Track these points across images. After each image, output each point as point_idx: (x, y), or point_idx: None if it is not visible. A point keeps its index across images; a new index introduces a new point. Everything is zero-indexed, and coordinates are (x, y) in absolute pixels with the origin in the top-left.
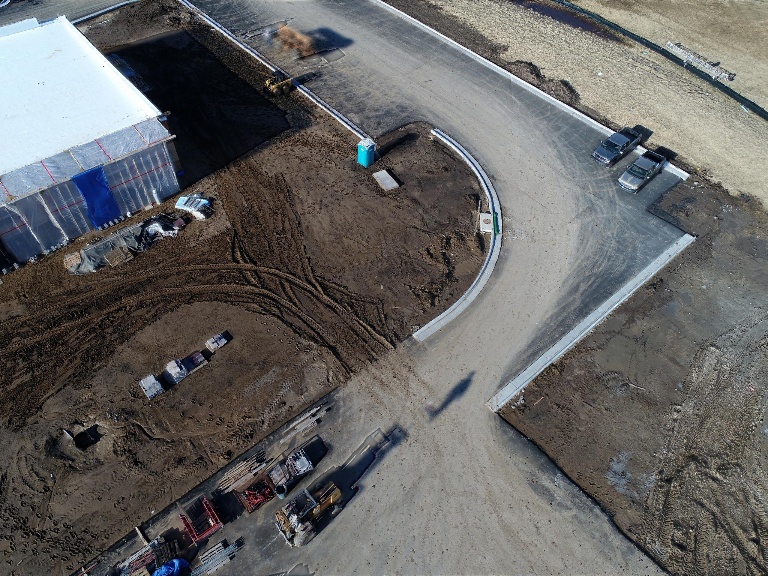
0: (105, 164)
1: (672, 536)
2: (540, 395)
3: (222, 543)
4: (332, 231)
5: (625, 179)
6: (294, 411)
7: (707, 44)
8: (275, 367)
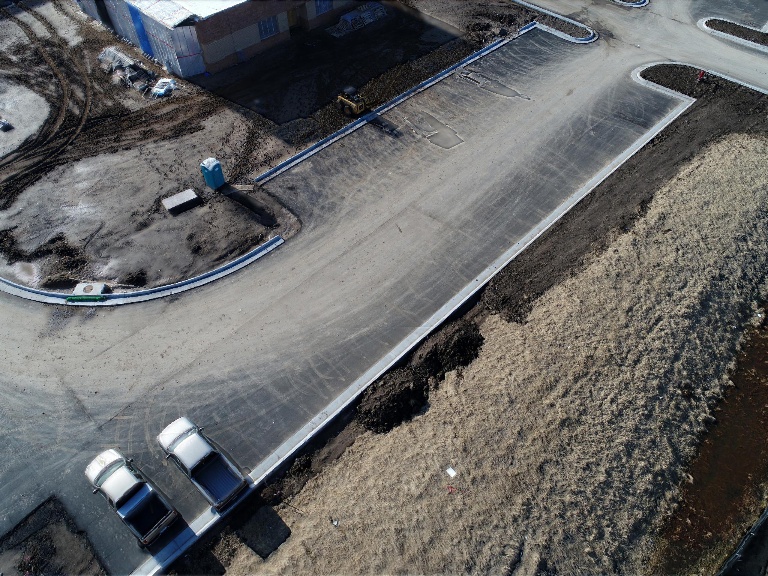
0: (141, 10)
1: None
2: None
3: None
4: (112, 170)
5: (104, 453)
6: None
7: None
8: None
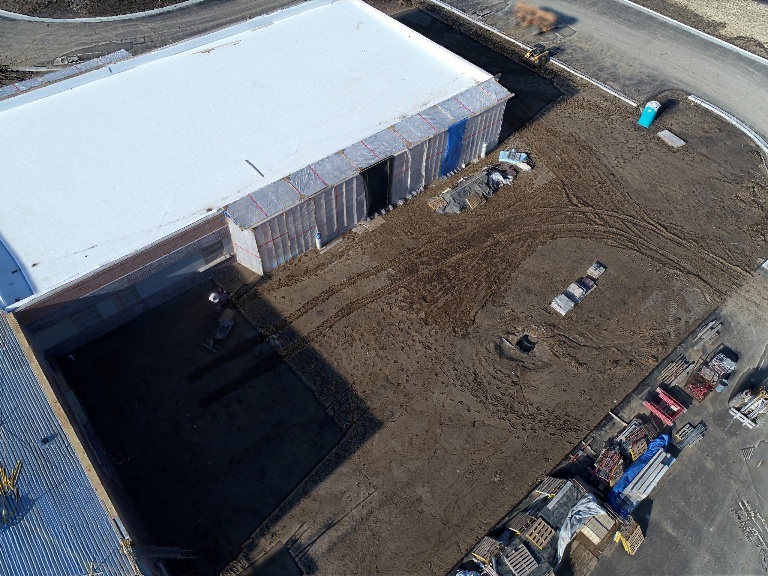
0: (469, 117)
1: None
2: None
3: (689, 424)
4: (645, 181)
5: None
6: (691, 325)
7: None
8: (656, 290)
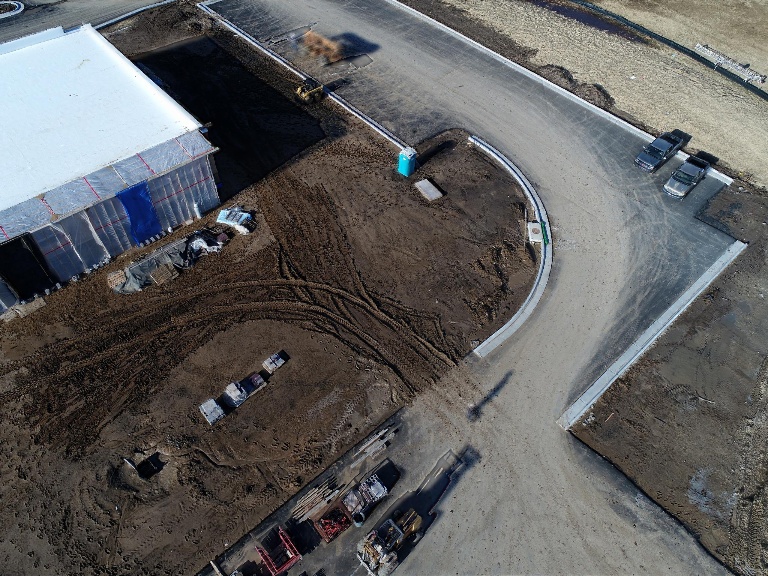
0: (149, 179)
1: (761, 556)
2: (610, 411)
3: (302, 575)
4: (379, 243)
5: (671, 185)
6: (361, 433)
7: (734, 46)
8: (336, 387)
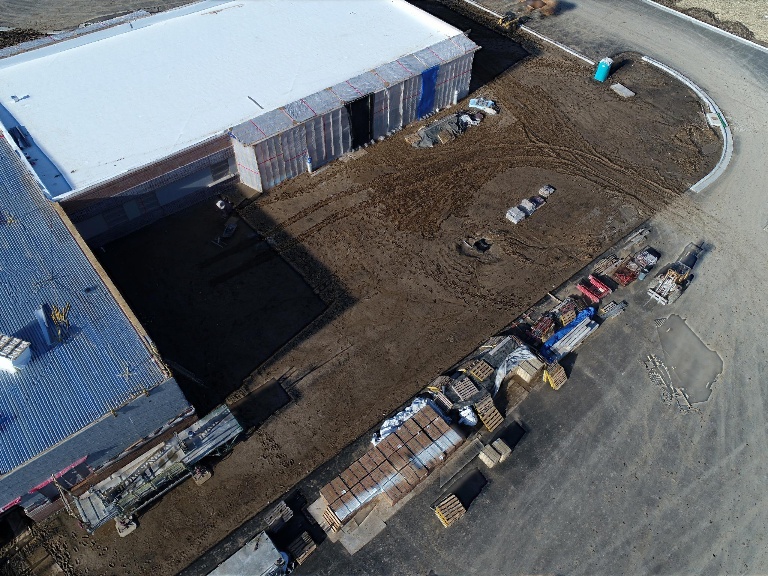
0: (441, 64)
1: None
2: None
3: (613, 302)
4: (596, 124)
5: None
6: (624, 232)
7: None
8: (596, 207)
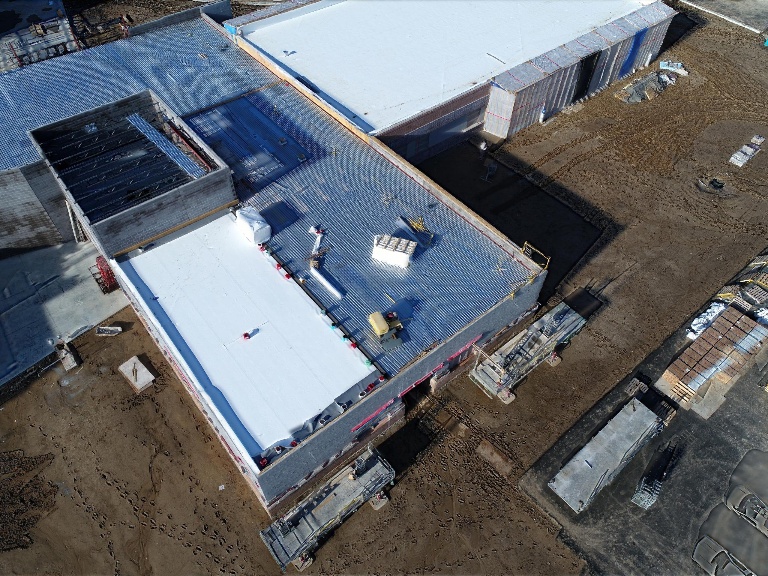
0: (649, 27)
1: None
2: None
3: None
4: None
5: None
6: None
7: None
8: None
